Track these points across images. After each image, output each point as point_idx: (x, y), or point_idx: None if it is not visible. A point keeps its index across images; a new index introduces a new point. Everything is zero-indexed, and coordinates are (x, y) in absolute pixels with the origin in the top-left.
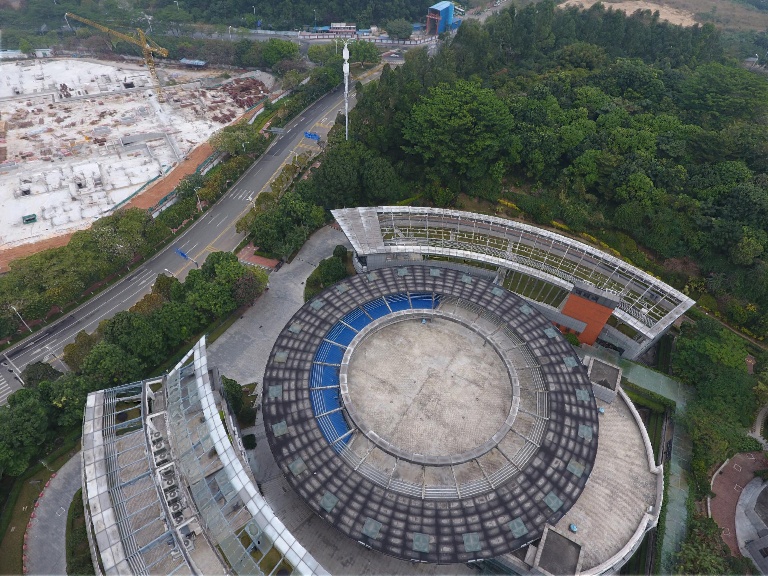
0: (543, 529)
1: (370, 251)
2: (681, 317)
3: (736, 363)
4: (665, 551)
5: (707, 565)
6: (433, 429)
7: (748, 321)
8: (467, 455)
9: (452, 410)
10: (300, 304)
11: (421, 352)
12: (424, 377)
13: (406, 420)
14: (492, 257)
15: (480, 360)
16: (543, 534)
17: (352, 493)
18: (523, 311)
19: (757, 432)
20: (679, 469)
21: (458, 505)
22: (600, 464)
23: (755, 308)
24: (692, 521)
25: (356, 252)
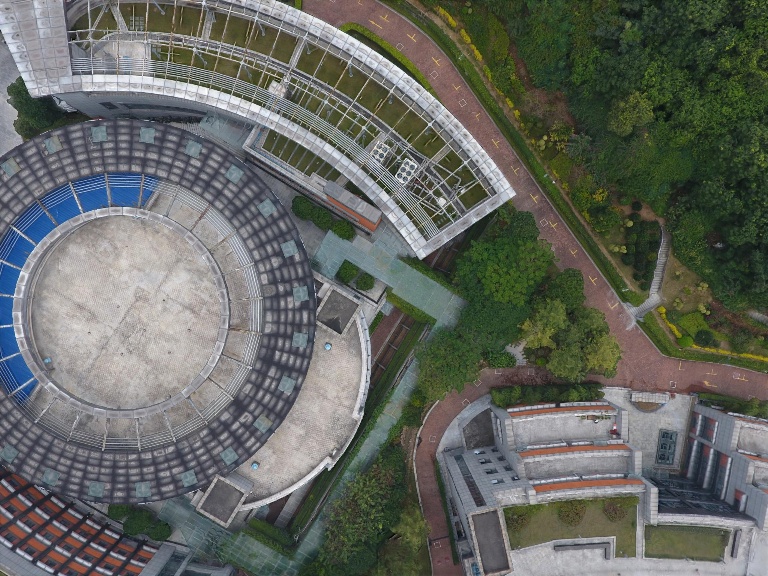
0: (212, 480)
1: (49, 89)
2: (524, 178)
3: (511, 297)
4: (350, 470)
5: (361, 503)
6: (134, 366)
7: (591, 208)
8: (151, 410)
9: (158, 344)
10: (16, 135)
11: (129, 264)
12: (130, 300)
13: (104, 355)
14: (240, 101)
15: (202, 276)
16: (211, 484)
17: (32, 445)
18: (262, 211)
19: (521, 347)
20: (401, 397)
21: (136, 457)
22: (305, 405)
23: (604, 197)
24: (378, 456)
25: (28, 90)
